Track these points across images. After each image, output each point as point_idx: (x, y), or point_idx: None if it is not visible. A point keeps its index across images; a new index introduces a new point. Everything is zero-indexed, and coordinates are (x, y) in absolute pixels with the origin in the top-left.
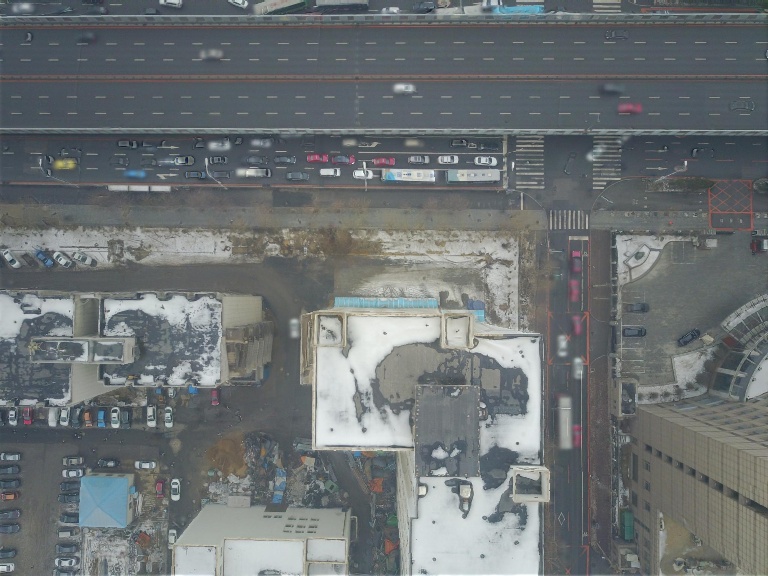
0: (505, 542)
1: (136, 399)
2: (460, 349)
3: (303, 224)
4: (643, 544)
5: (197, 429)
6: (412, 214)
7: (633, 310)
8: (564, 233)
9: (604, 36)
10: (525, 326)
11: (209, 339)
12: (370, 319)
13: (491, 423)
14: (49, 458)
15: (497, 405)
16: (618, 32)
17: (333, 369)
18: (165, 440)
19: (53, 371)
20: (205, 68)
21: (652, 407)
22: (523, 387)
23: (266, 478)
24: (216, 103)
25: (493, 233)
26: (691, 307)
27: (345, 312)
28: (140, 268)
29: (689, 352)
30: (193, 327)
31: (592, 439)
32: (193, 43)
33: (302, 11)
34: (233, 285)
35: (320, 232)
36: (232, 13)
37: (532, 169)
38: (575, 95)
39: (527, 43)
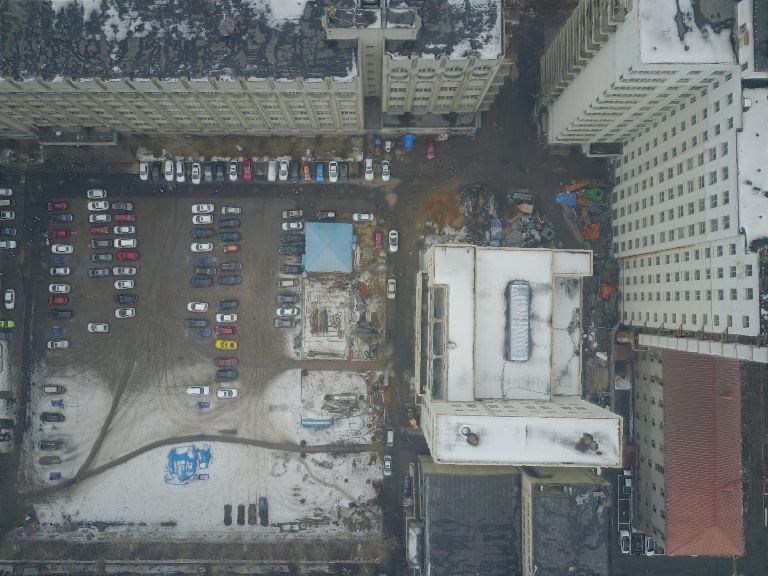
0: None
1: (352, 154)
2: None
3: None
4: None
5: (412, 183)
6: None
7: None
8: None
9: None
10: None
11: (488, 18)
12: None
13: None
14: (268, 213)
15: None
16: None
17: None
18: (381, 194)
19: (337, 50)
20: None
21: None
22: None
23: (483, 227)
24: None
25: None
26: None
27: None
28: None
29: None
30: (472, 6)
31: None
32: None
33: None
34: None
35: None
36: None
37: None
38: None
39: None
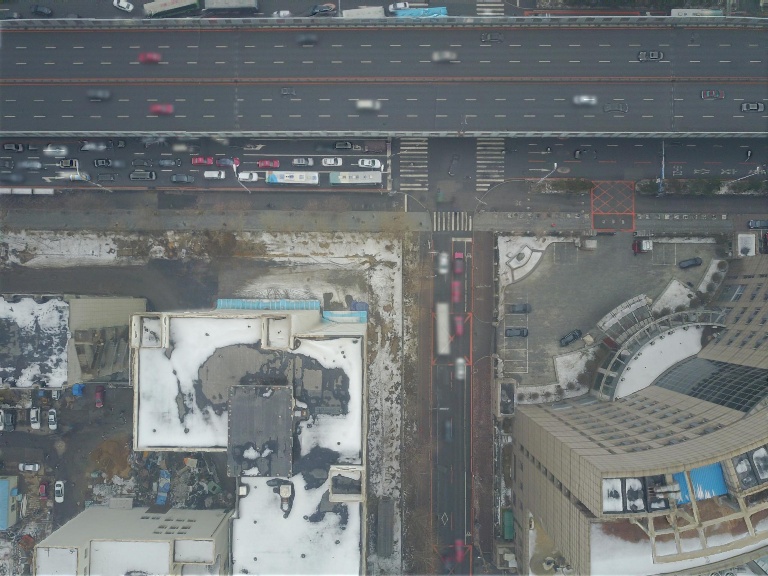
0: (326, 541)
1: (20, 401)
2: (282, 350)
3: (188, 226)
4: (518, 543)
5: (82, 431)
6: (296, 216)
7: (515, 311)
8: (448, 234)
9: (480, 39)
10: (409, 327)
11: (58, 341)
12: (192, 320)
13: (312, 423)
14: None
15: (319, 405)
16: (493, 35)
17: (156, 370)
18: (50, 442)
19: None
20: (86, 71)
21: (530, 407)
22: (344, 387)
23: (149, 480)
24: (97, 106)
25: (377, 235)
26: (573, 307)
27: (163, 314)
28: (25, 271)
29: (571, 352)
30: (42, 329)
31: (475, 439)
32: (74, 47)
33: (183, 15)
34: (118, 287)
35: (205, 234)
36: (117, 17)
37: (416, 171)
38: (452, 97)
39: (404, 46)
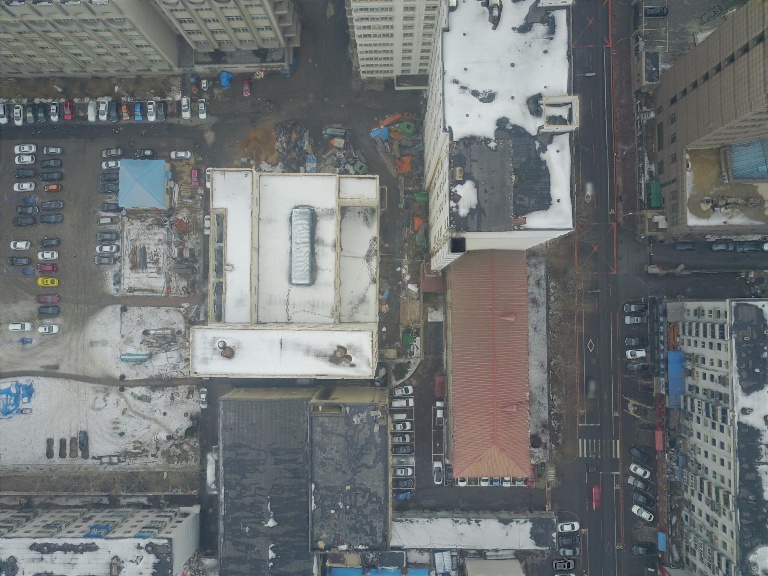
0: (534, 51)
1: (171, 93)
2: None
3: None
4: (670, 200)
5: (229, 121)
6: None
7: None
8: None
9: None
10: None
11: None
12: None
13: None
14: (89, 153)
15: None
16: None
17: None
18: (199, 132)
19: None
20: None
21: None
22: None
23: (297, 163)
24: None
25: None
26: None
27: None
28: None
29: (712, 29)
30: None
31: (616, 119)
32: None
33: None
34: None
35: None
36: None
37: None
38: None
39: None
